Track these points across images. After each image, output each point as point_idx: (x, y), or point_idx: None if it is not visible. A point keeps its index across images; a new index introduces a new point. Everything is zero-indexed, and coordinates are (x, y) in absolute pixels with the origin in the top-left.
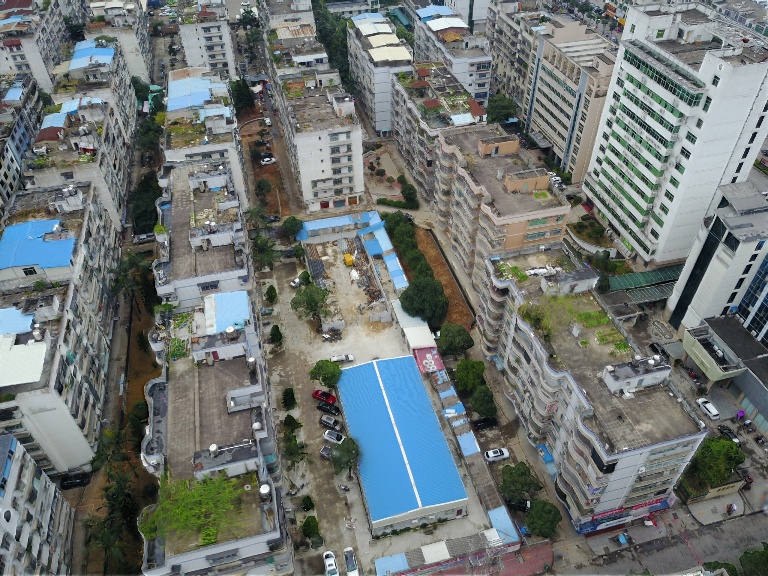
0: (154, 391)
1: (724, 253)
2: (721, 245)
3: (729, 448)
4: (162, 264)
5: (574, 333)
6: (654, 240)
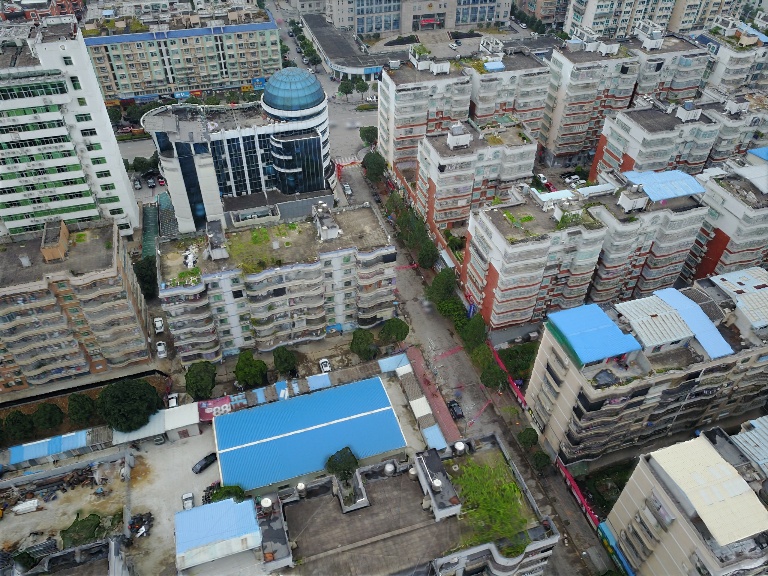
0: None
1: (203, 159)
2: (196, 157)
3: None
4: None
5: (277, 247)
6: (121, 216)
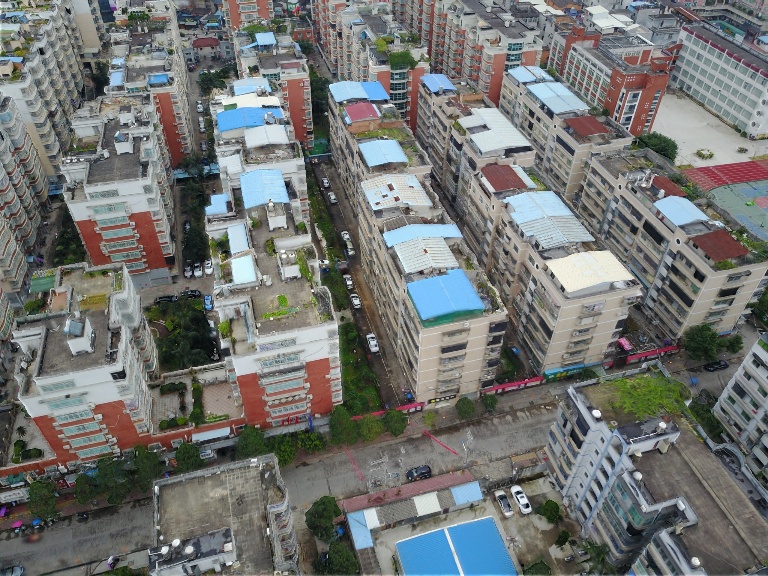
0: None
1: None
2: None
3: None
4: None
5: None
6: None
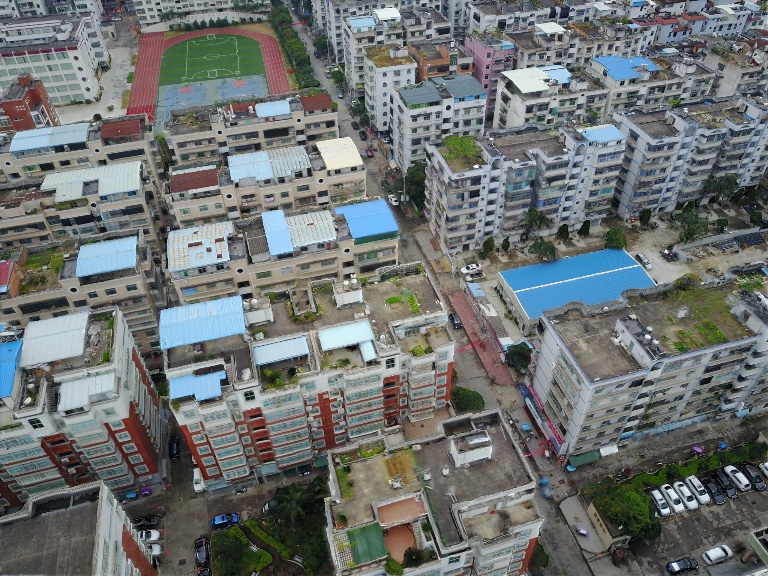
0: (533, 129)
1: None
2: None
3: (638, 511)
4: (642, 112)
5: None
6: None
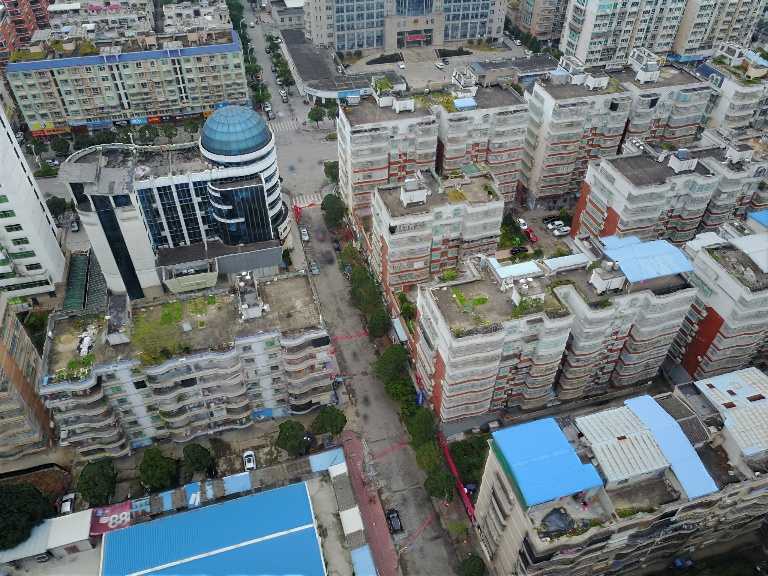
0: None
1: (126, 212)
2: (117, 210)
3: None
4: None
5: (188, 329)
6: (39, 271)
